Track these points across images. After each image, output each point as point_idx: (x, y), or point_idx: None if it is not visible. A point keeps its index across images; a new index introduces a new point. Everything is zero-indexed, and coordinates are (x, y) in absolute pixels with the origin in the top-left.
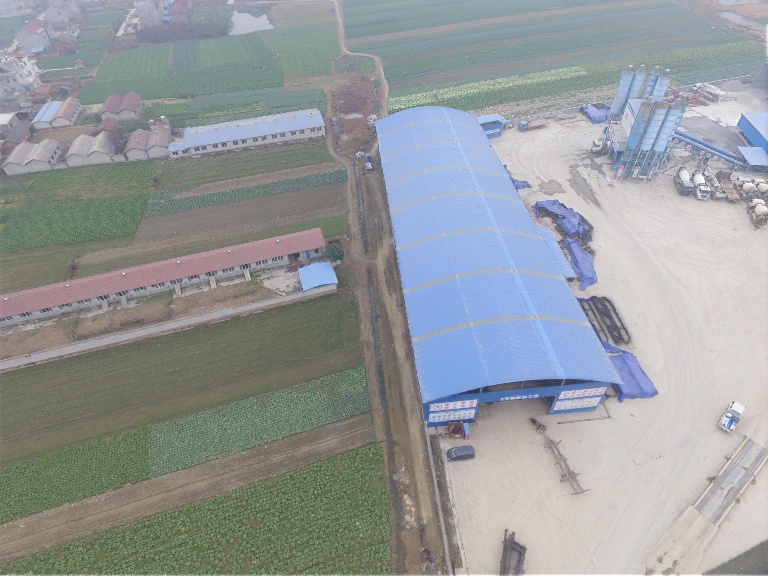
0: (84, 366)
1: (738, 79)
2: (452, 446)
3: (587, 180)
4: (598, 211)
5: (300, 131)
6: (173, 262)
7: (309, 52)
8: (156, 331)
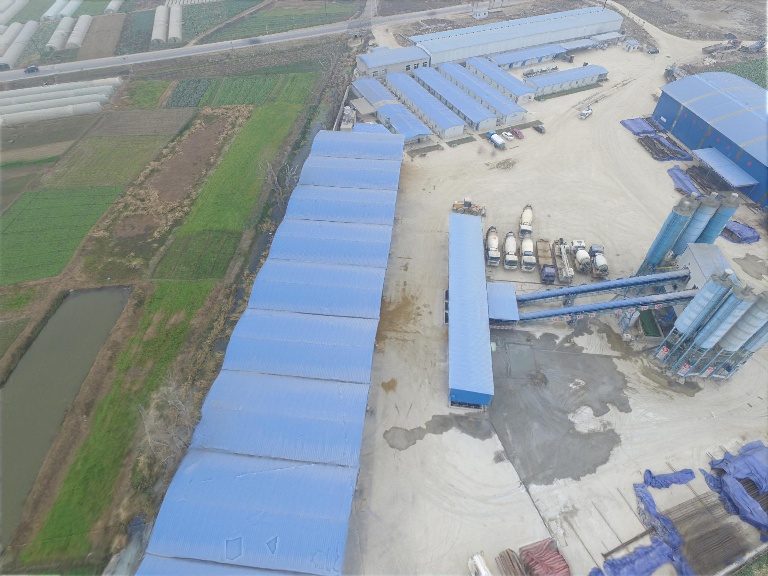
0: None
1: None
2: None
3: None
4: None
5: None
6: None
7: None
8: None
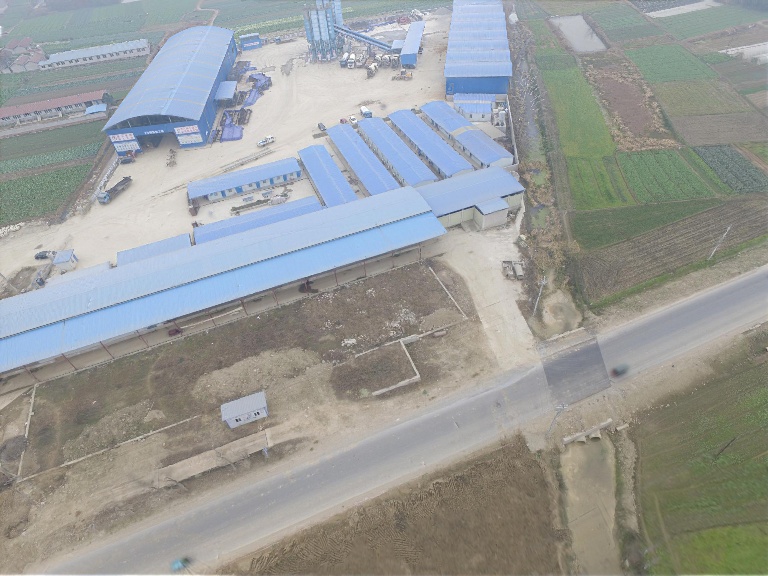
0: None
1: (449, 7)
2: None
3: (294, 64)
4: (285, 77)
5: (130, 51)
6: (15, 106)
7: (171, 10)
8: None
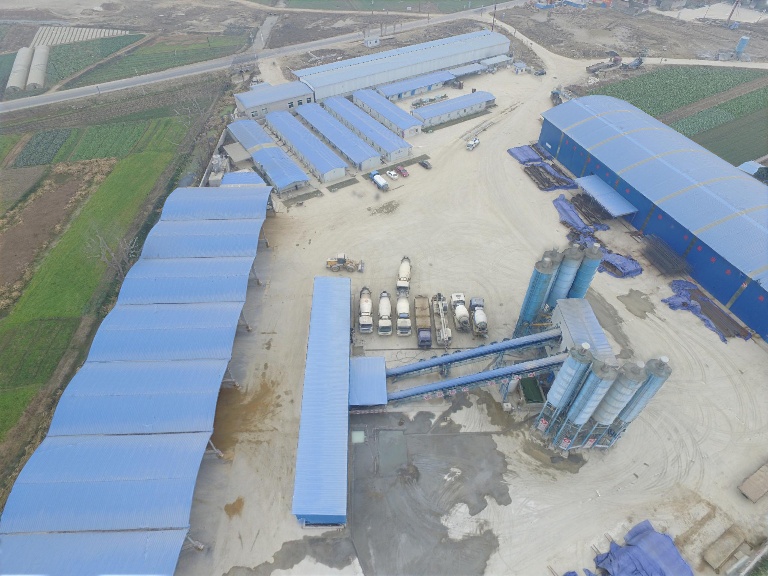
0: None
1: None
2: None
3: None
4: None
5: None
6: None
7: None
8: None
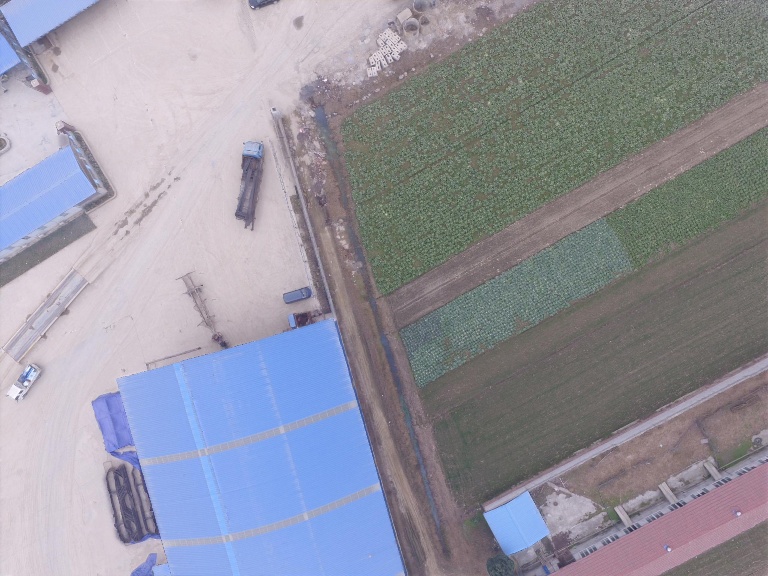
0: (764, 328)
1: None
2: (307, 304)
3: None
4: None
5: None
6: (747, 513)
7: None
8: (703, 394)
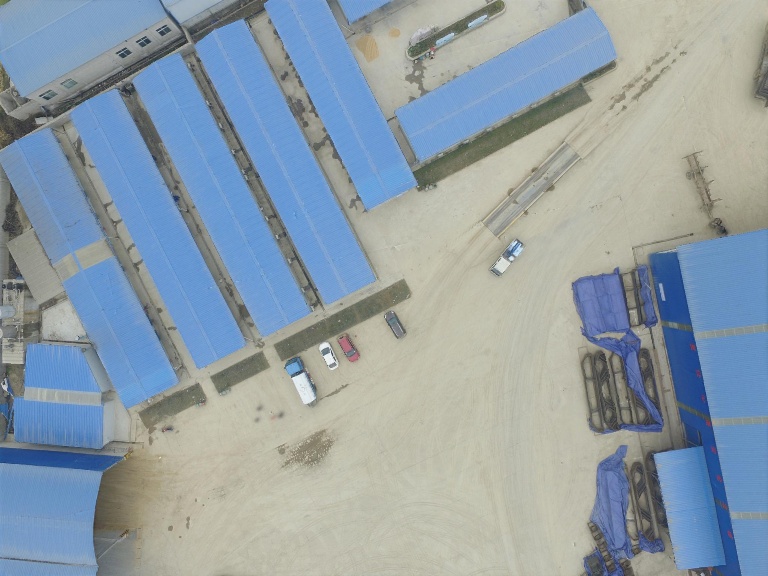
0: None
1: None
2: None
3: None
4: None
5: None
6: None
7: None
8: None
